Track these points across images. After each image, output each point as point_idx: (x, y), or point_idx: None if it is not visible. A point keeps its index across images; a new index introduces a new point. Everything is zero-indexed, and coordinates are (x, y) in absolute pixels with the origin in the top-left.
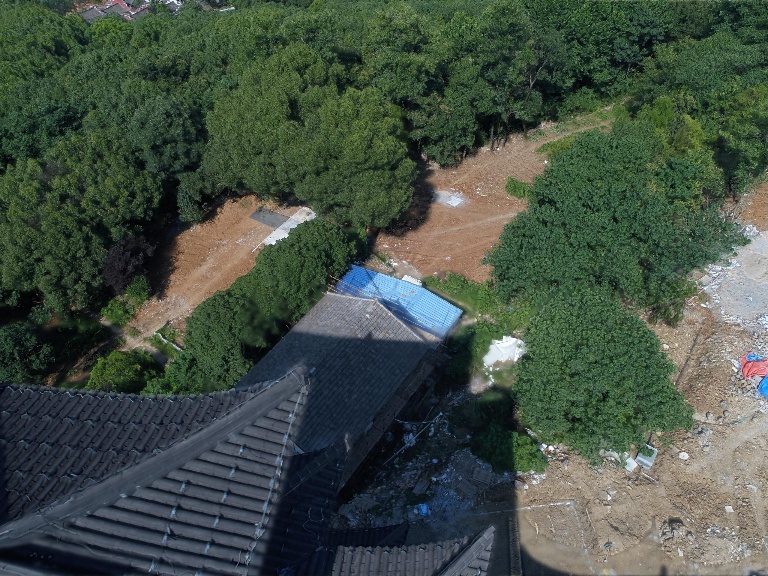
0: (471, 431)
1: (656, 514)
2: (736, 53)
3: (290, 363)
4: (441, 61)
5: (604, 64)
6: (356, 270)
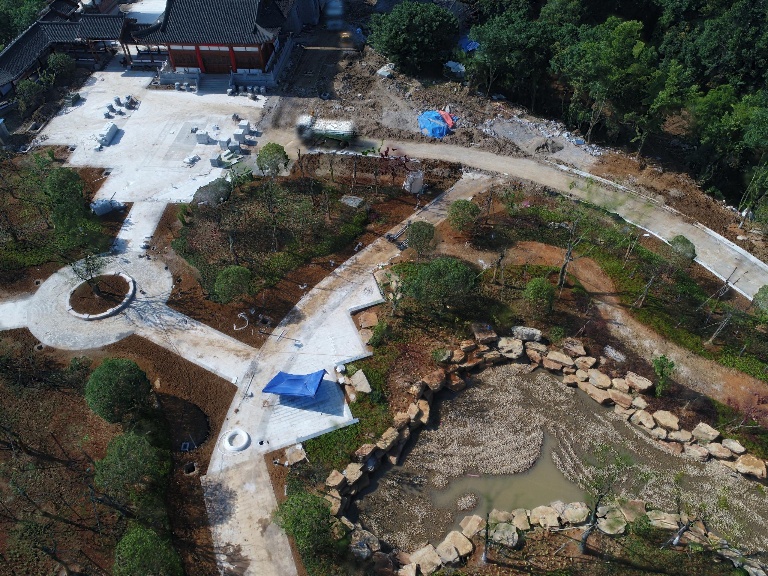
0: None
1: None
2: None
3: None
4: (710, 1)
5: None
6: None
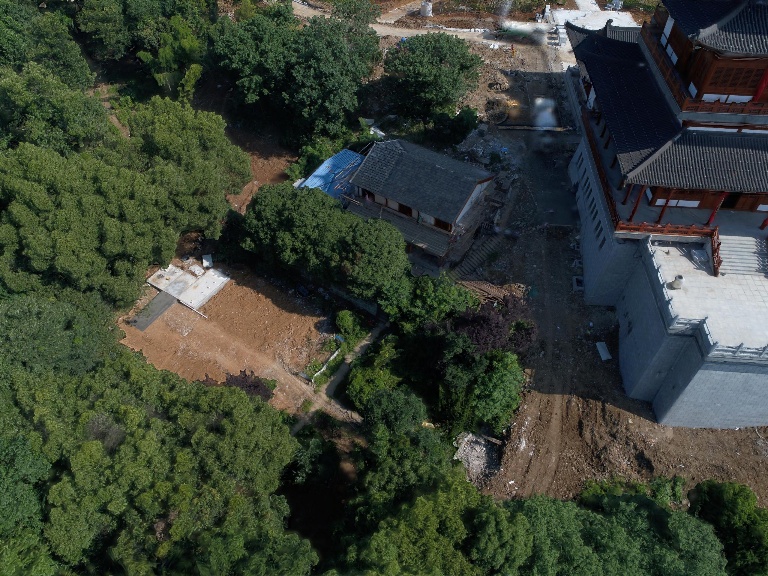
0: (441, 150)
1: None
2: None
3: (426, 185)
4: None
5: None
6: None
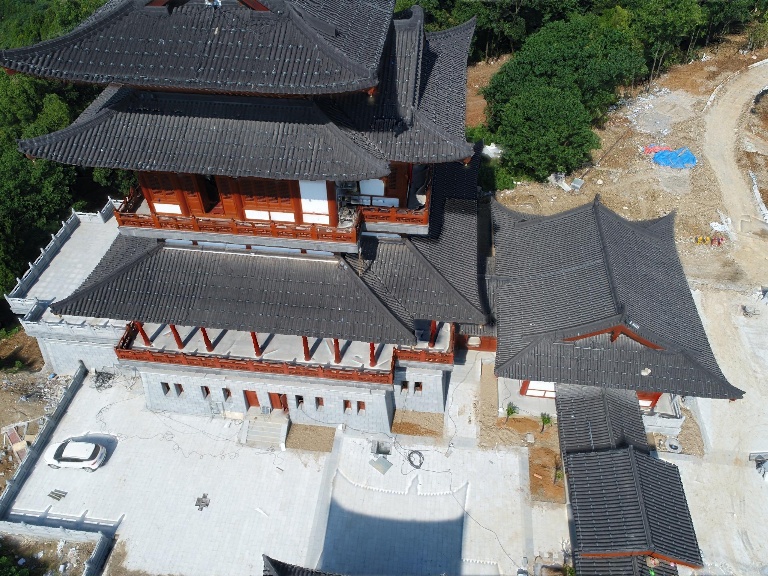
0: None
1: None
2: None
3: None
4: None
5: (574, 5)
6: None
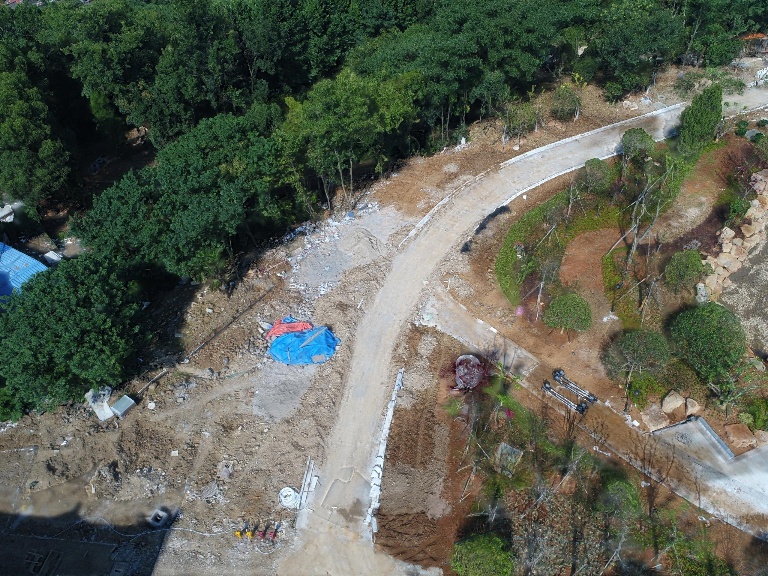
0: None
1: (104, 458)
2: (415, 42)
3: None
4: (136, 50)
5: None
6: None
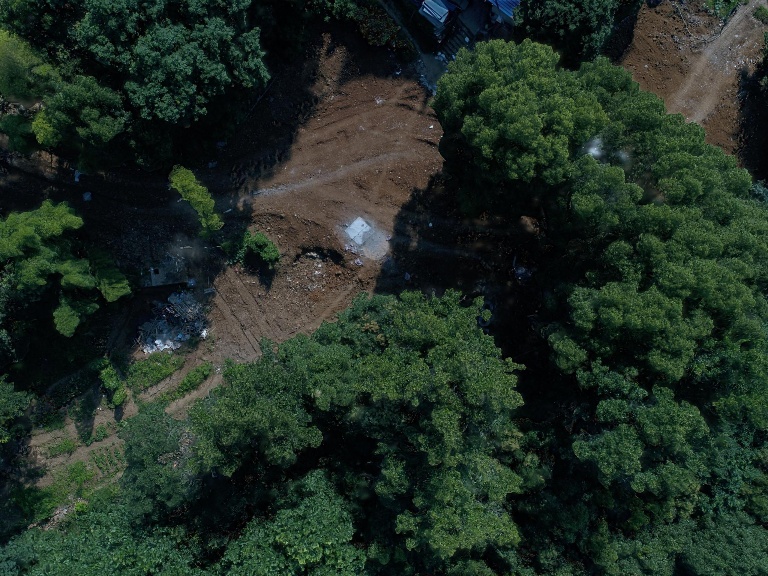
0: None
1: None
2: None
3: None
4: None
5: None
6: (509, 6)
